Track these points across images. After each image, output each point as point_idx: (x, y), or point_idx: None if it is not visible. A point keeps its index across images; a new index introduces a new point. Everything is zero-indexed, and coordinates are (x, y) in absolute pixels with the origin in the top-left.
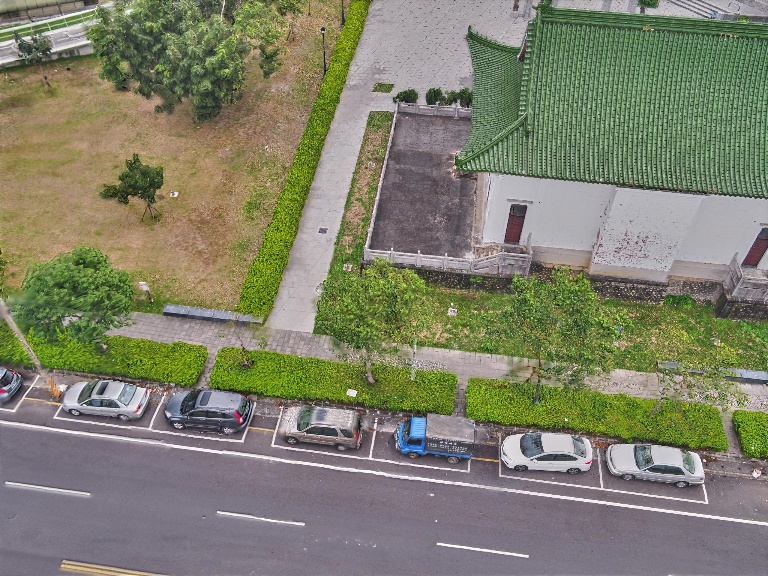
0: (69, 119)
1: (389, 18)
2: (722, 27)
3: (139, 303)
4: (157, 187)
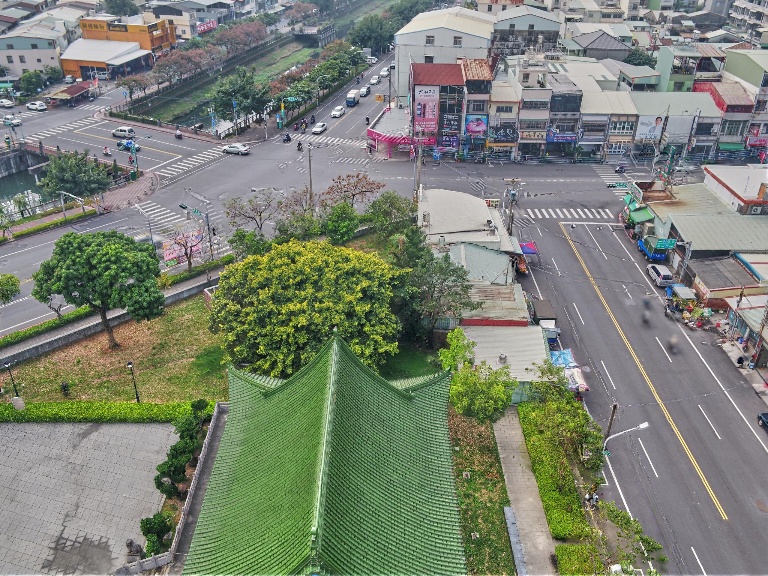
0: None
1: None
2: None
3: None
4: None
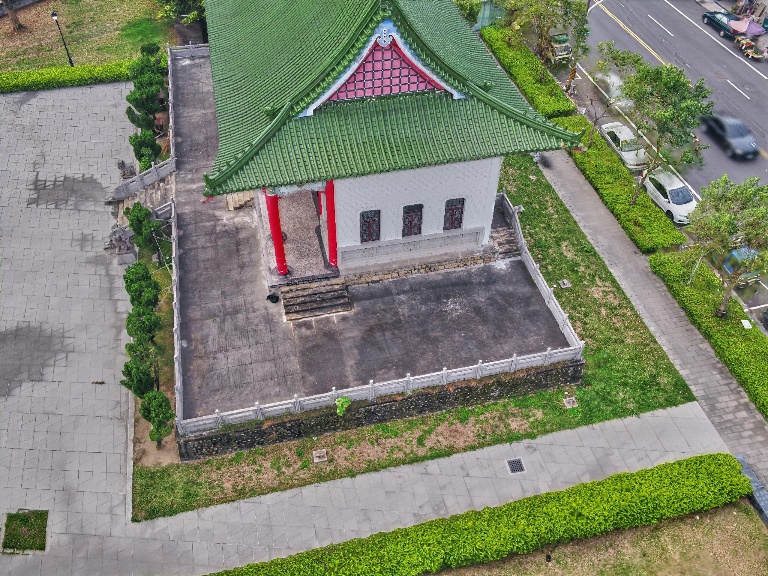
0: None
1: None
2: None
3: None
4: None
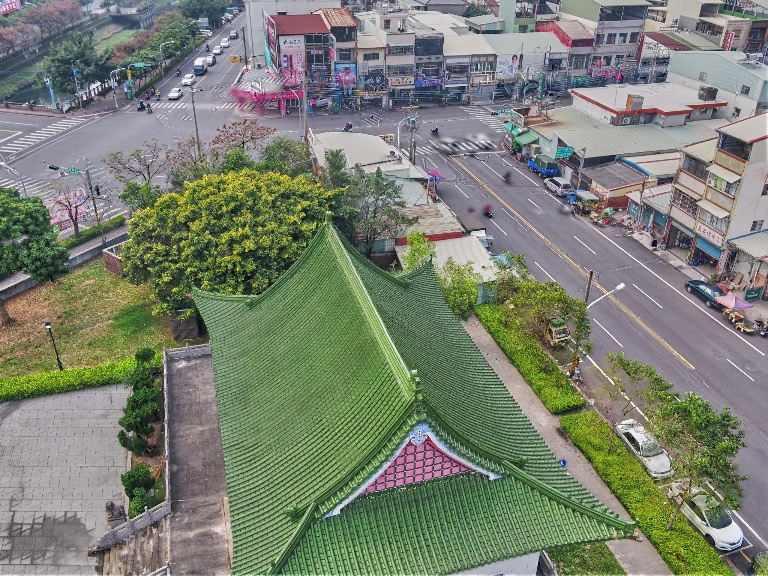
0: None
1: None
2: None
3: None
4: None
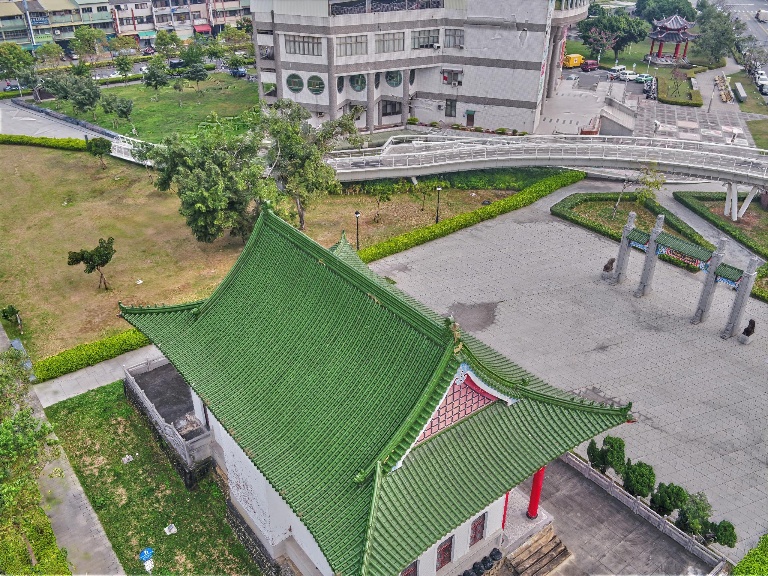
0: (170, 214)
1: (484, 235)
2: (370, 287)
3: (16, 331)
4: (94, 263)
